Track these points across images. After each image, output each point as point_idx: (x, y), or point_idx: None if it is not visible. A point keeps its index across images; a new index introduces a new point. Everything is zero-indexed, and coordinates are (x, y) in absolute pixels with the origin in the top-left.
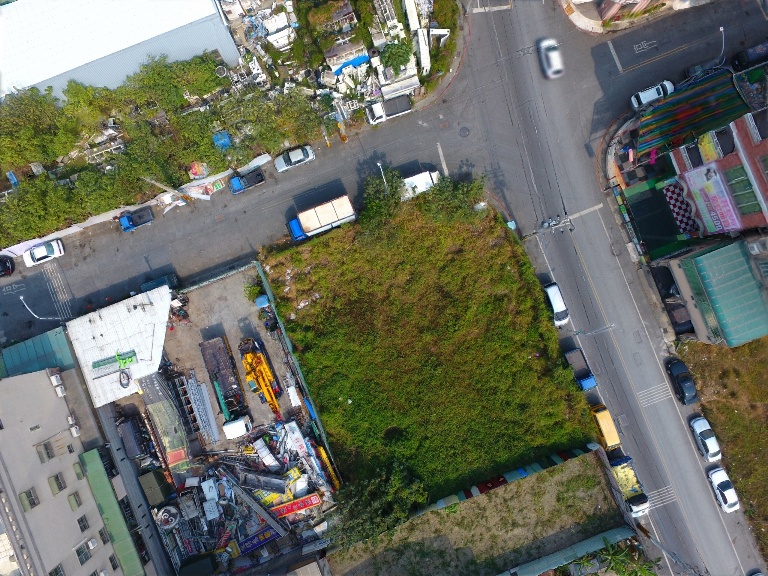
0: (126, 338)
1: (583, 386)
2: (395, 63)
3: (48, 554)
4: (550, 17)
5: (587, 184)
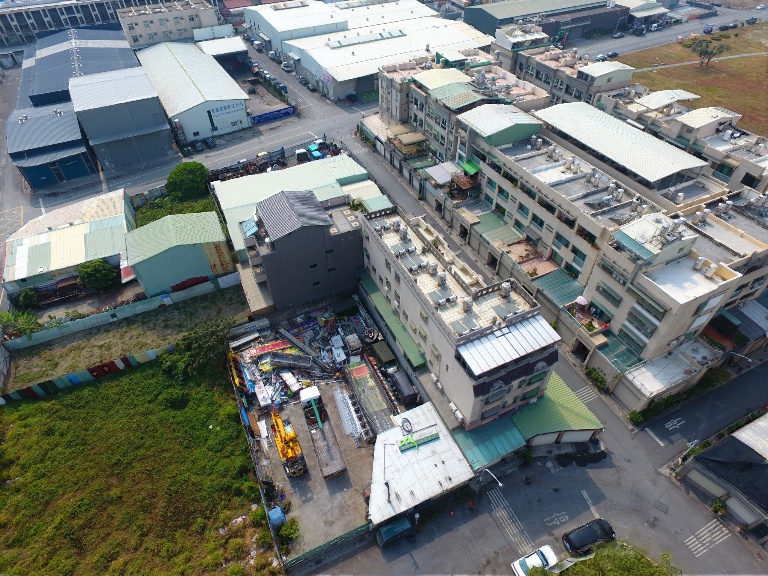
0: (411, 464)
1: None
2: None
3: (405, 288)
4: None
5: None
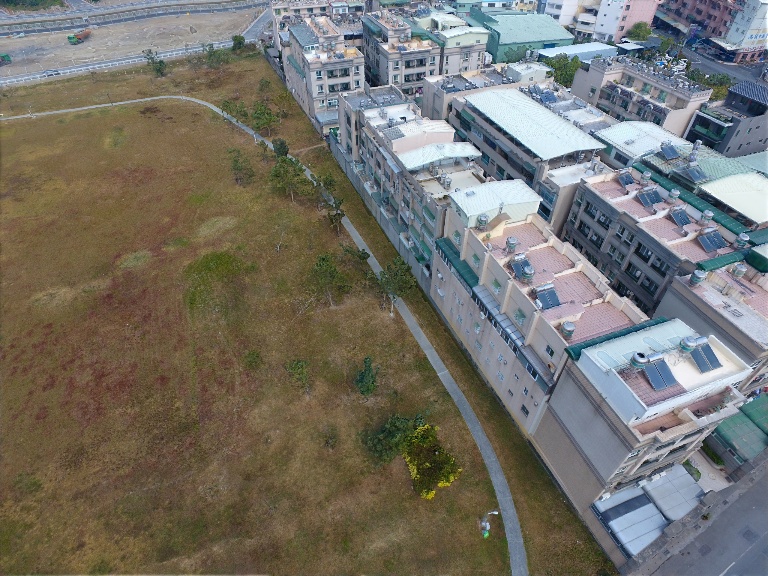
0: None
1: None
2: (676, 60)
3: None
4: (717, 63)
5: (764, 84)
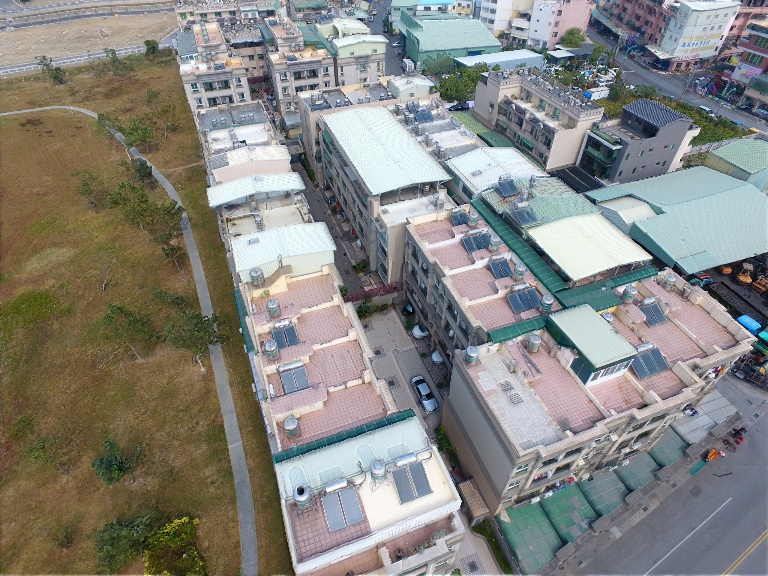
0: None
1: (736, 123)
2: (605, 70)
3: None
4: (651, 72)
5: None
